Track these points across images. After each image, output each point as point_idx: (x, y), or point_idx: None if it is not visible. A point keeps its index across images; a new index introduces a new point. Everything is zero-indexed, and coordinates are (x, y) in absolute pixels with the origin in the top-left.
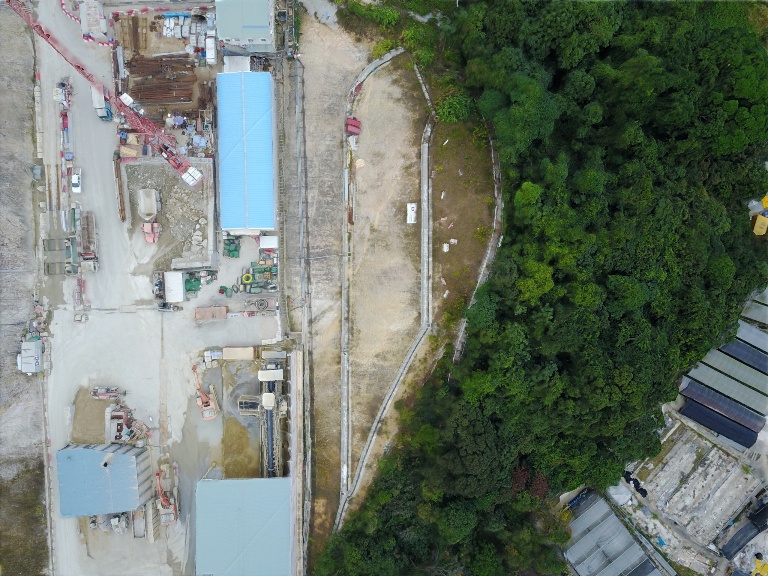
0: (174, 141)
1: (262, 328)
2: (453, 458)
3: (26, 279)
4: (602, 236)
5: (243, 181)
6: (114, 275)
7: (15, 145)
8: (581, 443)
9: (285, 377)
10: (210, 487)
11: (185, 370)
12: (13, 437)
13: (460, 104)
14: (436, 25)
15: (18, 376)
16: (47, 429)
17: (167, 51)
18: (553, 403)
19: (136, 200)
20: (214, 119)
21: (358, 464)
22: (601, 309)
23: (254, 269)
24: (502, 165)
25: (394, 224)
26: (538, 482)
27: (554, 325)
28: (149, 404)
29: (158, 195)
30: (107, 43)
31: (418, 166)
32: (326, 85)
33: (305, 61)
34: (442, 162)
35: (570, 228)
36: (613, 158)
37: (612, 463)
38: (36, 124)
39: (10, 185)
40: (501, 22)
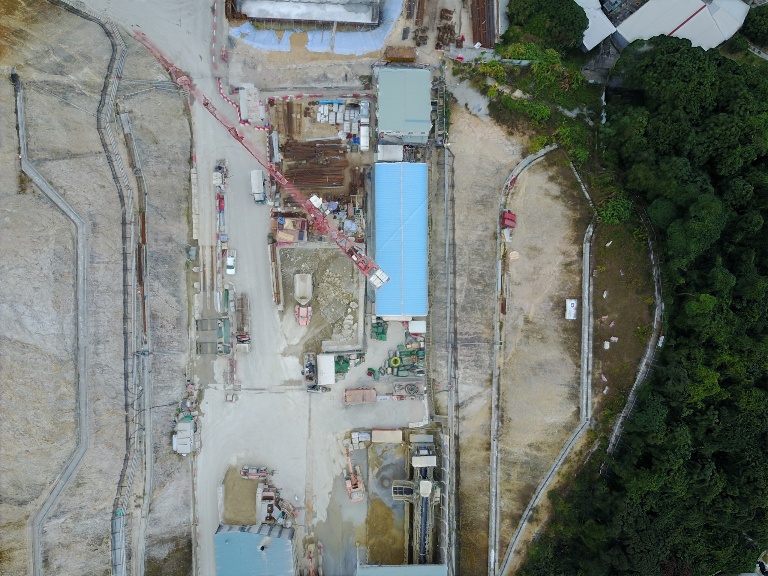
0: (327, 226)
1: (411, 412)
2: (617, 554)
3: (180, 359)
4: (765, 342)
5: (399, 269)
6: (264, 356)
7: (173, 227)
8: (725, 534)
9: (438, 463)
10: (369, 574)
11: (331, 450)
12: (165, 517)
13: (623, 207)
14: (585, 120)
15: (171, 456)
16: (196, 508)
17: (320, 136)
18: (711, 500)
19: (288, 283)
20: (365, 204)
21: (507, 550)
22: (762, 412)
23: (401, 352)
24: (665, 268)
25: (551, 318)
26: (686, 573)
27: (719, 428)
28: (295, 483)
29: None
30: (263, 128)
31: (579, 264)
32: (478, 176)
33: (455, 150)
34: (605, 262)
35: (740, 336)
36: (763, 260)
37: (752, 553)
38: (192, 206)
39: (168, 267)
40: (666, 130)
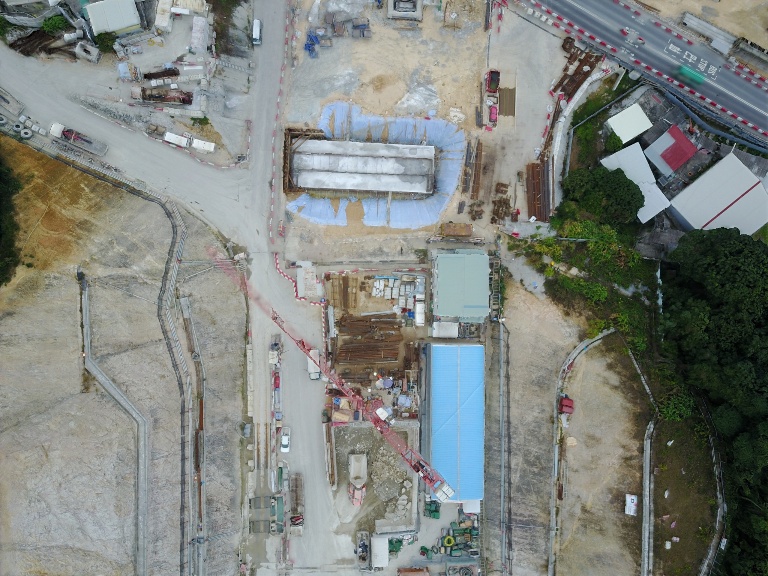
0: (382, 403)
1: None
2: None
3: (233, 539)
4: None
5: (456, 454)
6: (317, 534)
7: (229, 406)
8: None
9: None
10: None
11: None
12: None
13: (685, 405)
14: (640, 299)
15: None
16: None
17: (375, 310)
18: None
19: (342, 460)
20: (419, 380)
21: None
22: None
23: (454, 530)
24: (728, 471)
25: (610, 511)
26: None
27: None
28: None
29: None
30: (319, 303)
31: (639, 460)
32: (534, 356)
33: (510, 326)
34: (666, 461)
35: None
36: None
37: None
38: (247, 382)
39: (224, 448)
40: (728, 330)
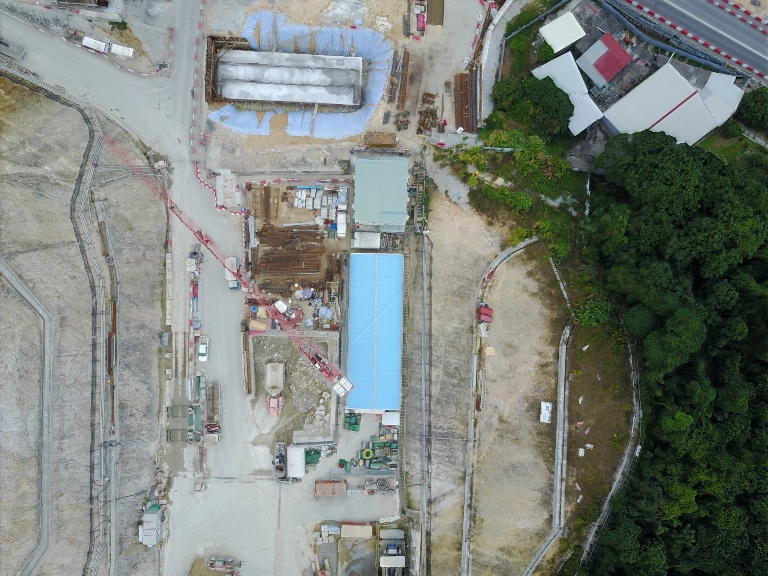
0: (301, 314)
1: (382, 508)
2: None
3: (149, 447)
4: (747, 459)
5: (372, 362)
6: (235, 444)
7: (146, 313)
8: None
9: (407, 564)
10: None
11: (300, 542)
12: None
13: (601, 309)
14: (567, 211)
15: (137, 546)
16: None
17: (297, 221)
18: None
19: (261, 370)
20: (341, 291)
21: None
22: (742, 532)
23: (374, 443)
24: (644, 376)
25: (526, 419)
26: None
27: (696, 548)
28: (263, 575)
29: (284, 368)
30: (239, 213)
31: (555, 366)
32: (456, 266)
33: (434, 238)
34: (581, 366)
35: (719, 455)
36: (750, 365)
37: None
38: (166, 291)
39: (140, 354)
40: (647, 232)
